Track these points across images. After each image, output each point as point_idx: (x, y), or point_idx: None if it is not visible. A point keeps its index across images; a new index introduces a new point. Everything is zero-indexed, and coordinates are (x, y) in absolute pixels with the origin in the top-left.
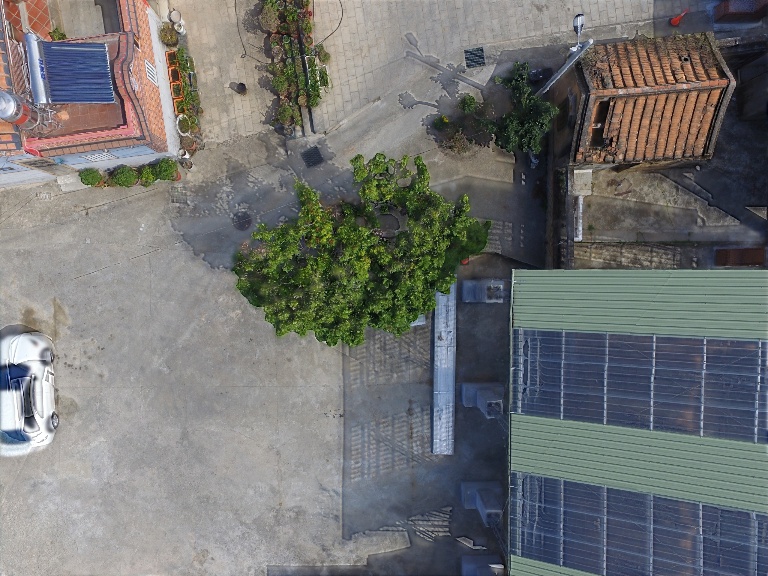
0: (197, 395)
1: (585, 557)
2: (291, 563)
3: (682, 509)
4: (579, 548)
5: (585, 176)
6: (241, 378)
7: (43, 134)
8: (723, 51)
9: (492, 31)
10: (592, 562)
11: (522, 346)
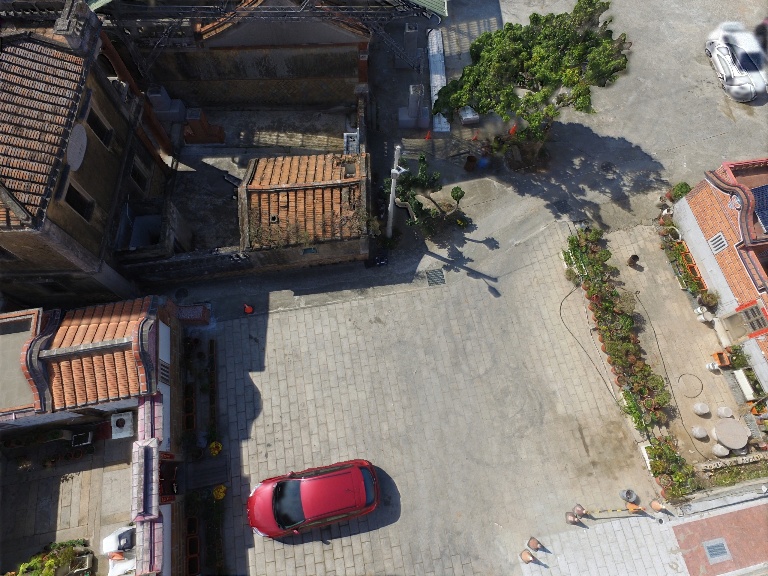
0: None
1: None
2: None
3: None
4: None
5: None
6: None
7: None
8: None
9: (421, 300)
10: None
11: None
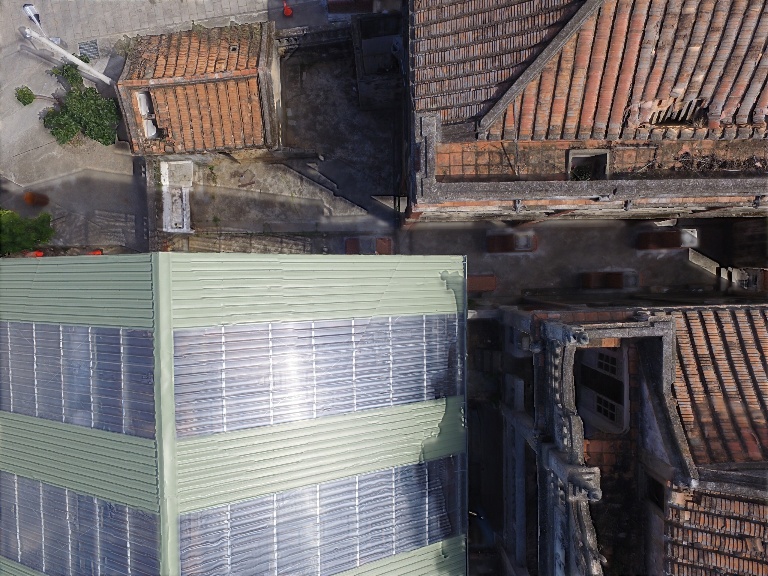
0: None
1: (8, 544)
2: None
3: (57, 495)
4: (4, 535)
5: (184, 167)
6: None
7: None
8: (307, 41)
9: (105, 24)
10: (12, 549)
11: None
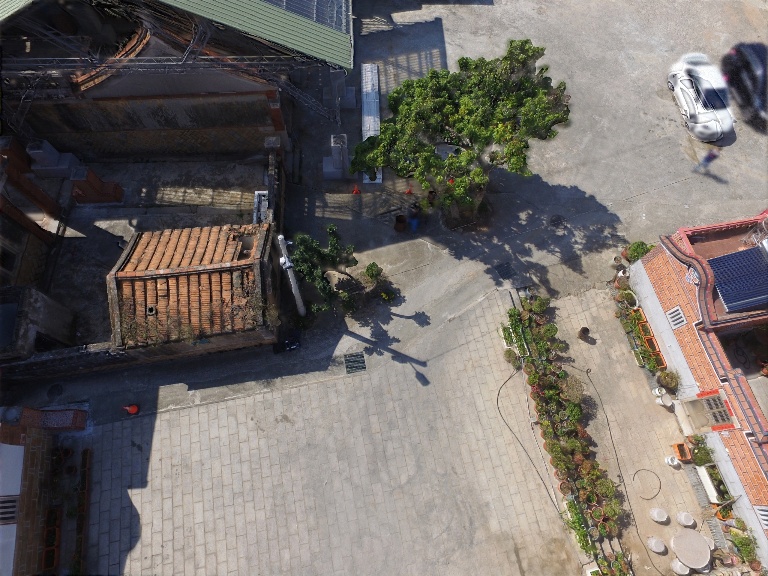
0: None
1: None
2: (477, 6)
3: None
4: None
5: None
6: None
7: (755, 230)
8: None
9: (337, 391)
10: None
11: (344, 24)
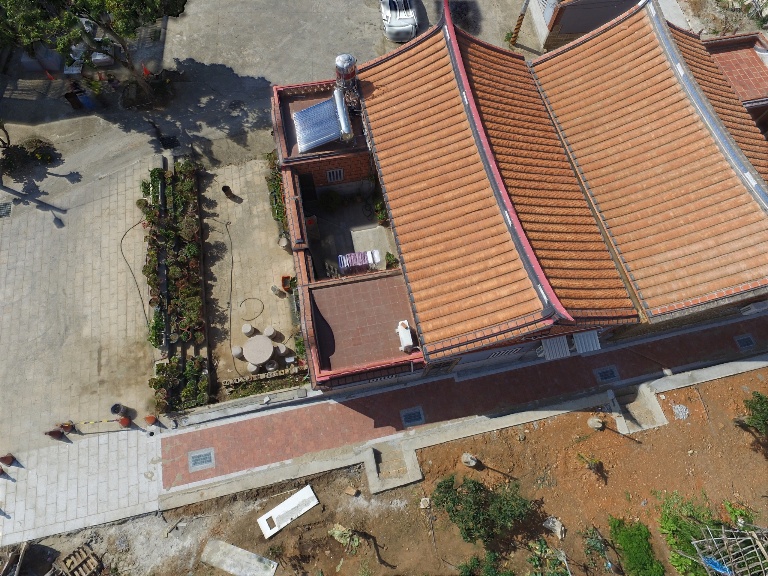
0: (278, 8)
1: None
2: None
3: None
4: None
5: None
6: (245, 17)
7: None
8: None
9: None
10: None
11: None
